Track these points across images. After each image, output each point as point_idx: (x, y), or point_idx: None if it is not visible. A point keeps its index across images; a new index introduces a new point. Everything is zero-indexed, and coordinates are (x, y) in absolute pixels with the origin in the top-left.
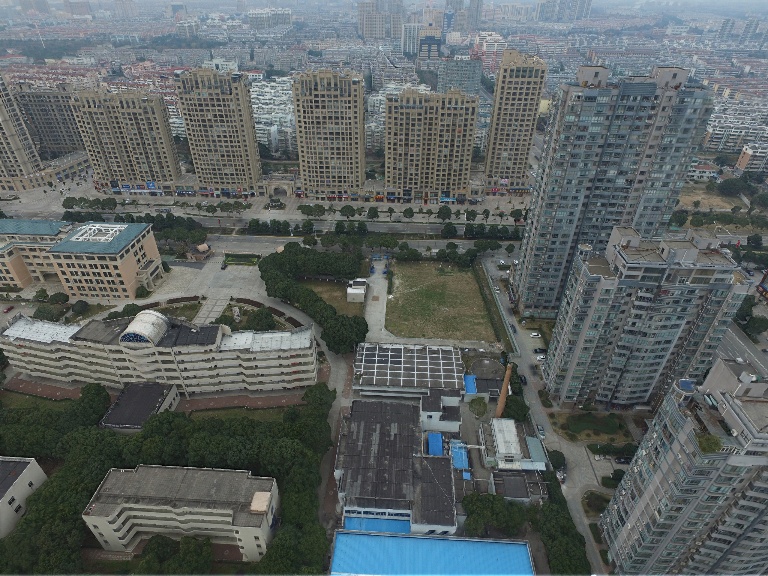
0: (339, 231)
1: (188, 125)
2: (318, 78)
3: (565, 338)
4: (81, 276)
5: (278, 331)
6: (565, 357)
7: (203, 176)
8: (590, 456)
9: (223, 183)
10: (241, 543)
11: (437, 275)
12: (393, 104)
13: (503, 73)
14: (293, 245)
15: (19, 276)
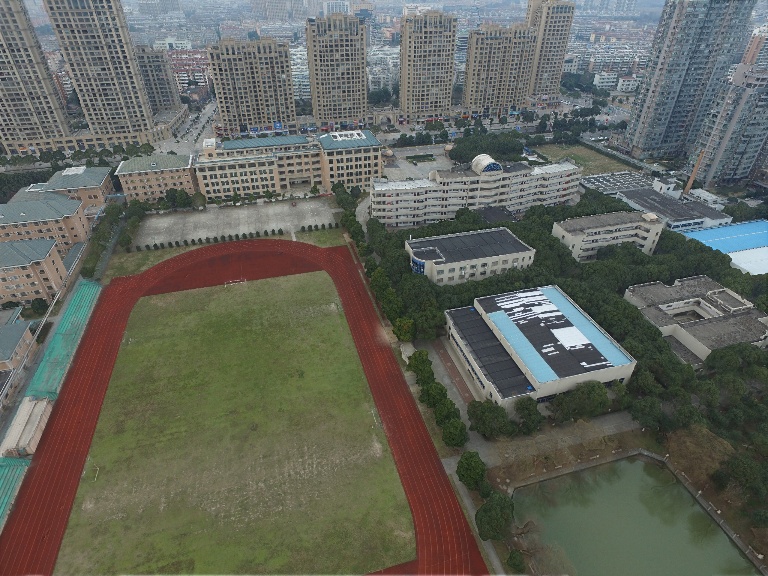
0: (469, 135)
1: (316, 66)
2: (428, 17)
3: (714, 138)
4: (345, 170)
5: (550, 164)
6: (715, 150)
7: (324, 113)
8: (742, 200)
9: (341, 117)
10: (646, 242)
11: (562, 150)
12: (480, 37)
13: (547, 10)
14: (468, 138)
15: (279, 182)
